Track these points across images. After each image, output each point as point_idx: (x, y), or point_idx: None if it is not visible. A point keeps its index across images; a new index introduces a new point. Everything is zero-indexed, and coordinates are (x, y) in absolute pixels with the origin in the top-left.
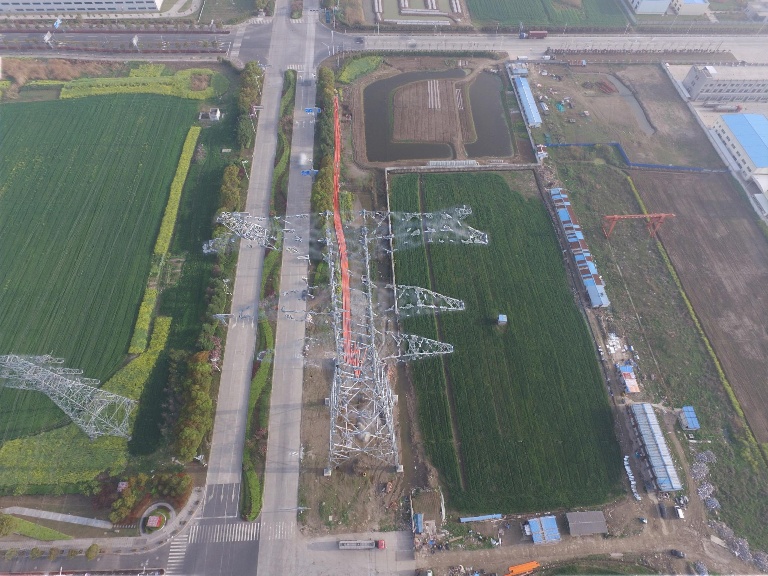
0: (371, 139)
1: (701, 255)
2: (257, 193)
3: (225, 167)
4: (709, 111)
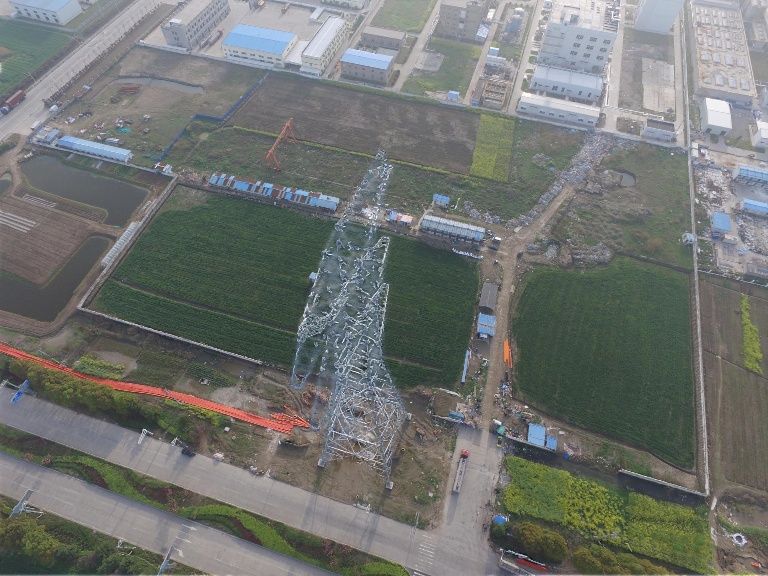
0: (20, 308)
1: (328, 126)
2: None
3: None
4: (209, 48)
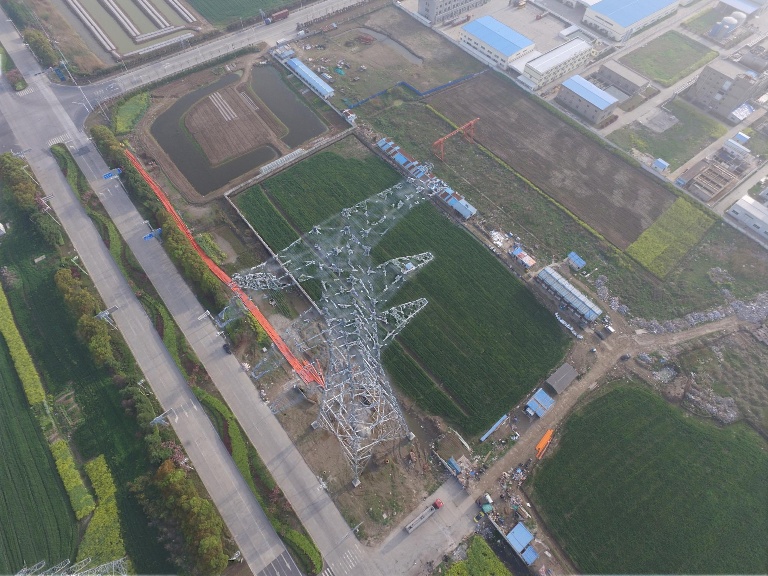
0: (190, 174)
1: (511, 140)
2: (107, 283)
3: (51, 276)
4: (450, 28)
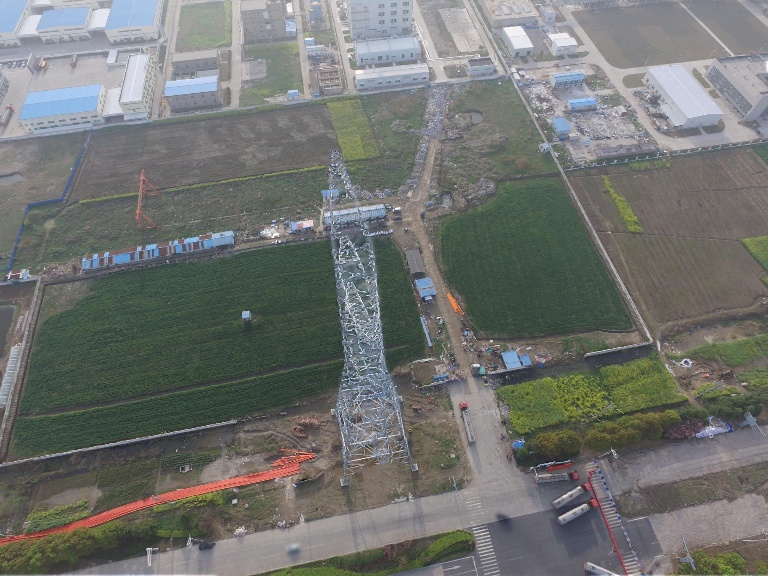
0: None
1: (184, 165)
2: None
3: None
4: (4, 130)
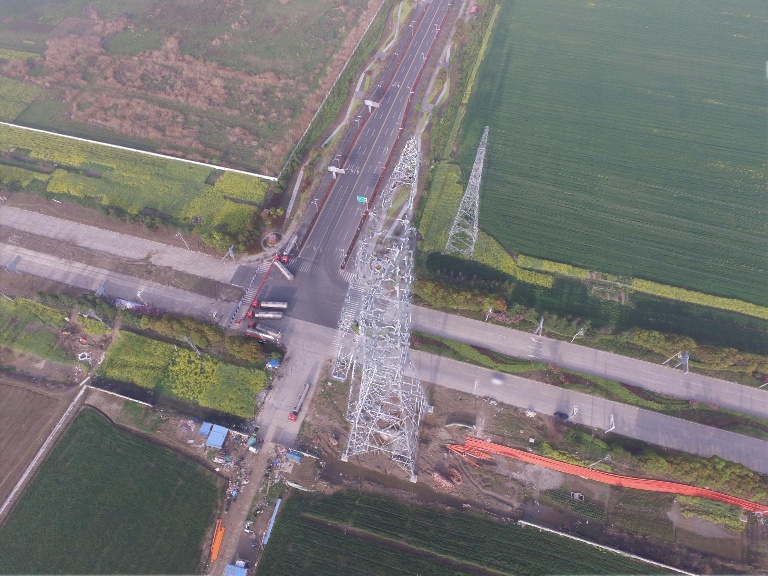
0: None
1: None
2: (733, 394)
3: None
4: None
